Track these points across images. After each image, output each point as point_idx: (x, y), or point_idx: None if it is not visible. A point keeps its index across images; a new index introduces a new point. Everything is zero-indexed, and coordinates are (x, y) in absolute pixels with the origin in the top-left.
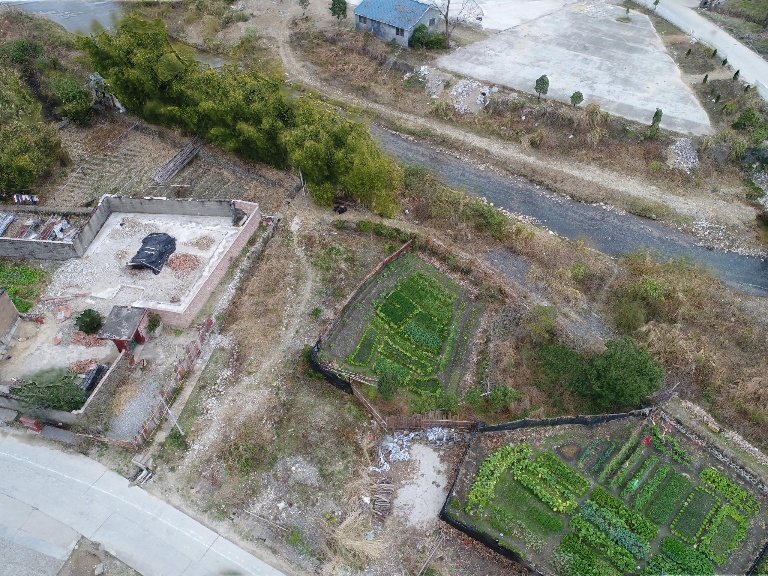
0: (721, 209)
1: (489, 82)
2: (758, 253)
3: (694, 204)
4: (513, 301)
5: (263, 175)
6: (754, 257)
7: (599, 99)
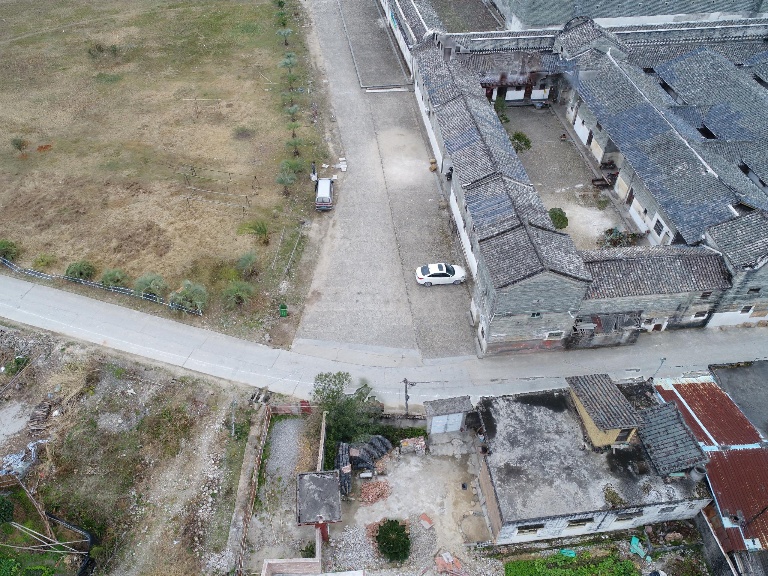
0: None
1: None
2: None
3: None
4: None
5: None
6: None
7: None
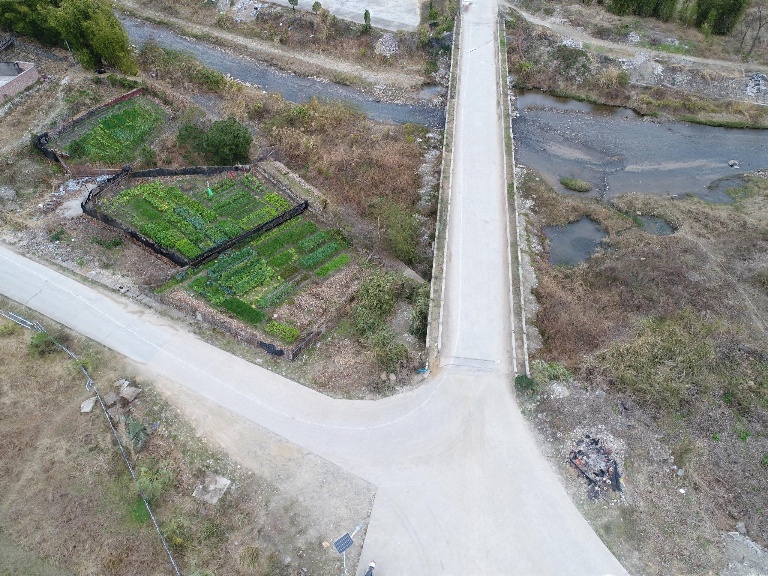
0: (400, 78)
1: (264, 1)
2: (410, 103)
3: (382, 76)
4: None
5: (55, 54)
6: (406, 105)
7: (343, 11)
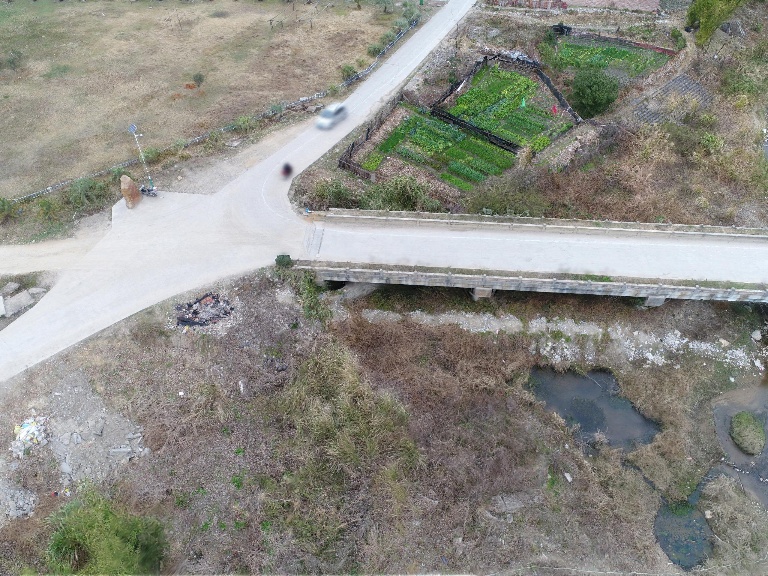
0: None
1: None
2: None
3: None
4: (645, 81)
5: None
6: None
7: None
